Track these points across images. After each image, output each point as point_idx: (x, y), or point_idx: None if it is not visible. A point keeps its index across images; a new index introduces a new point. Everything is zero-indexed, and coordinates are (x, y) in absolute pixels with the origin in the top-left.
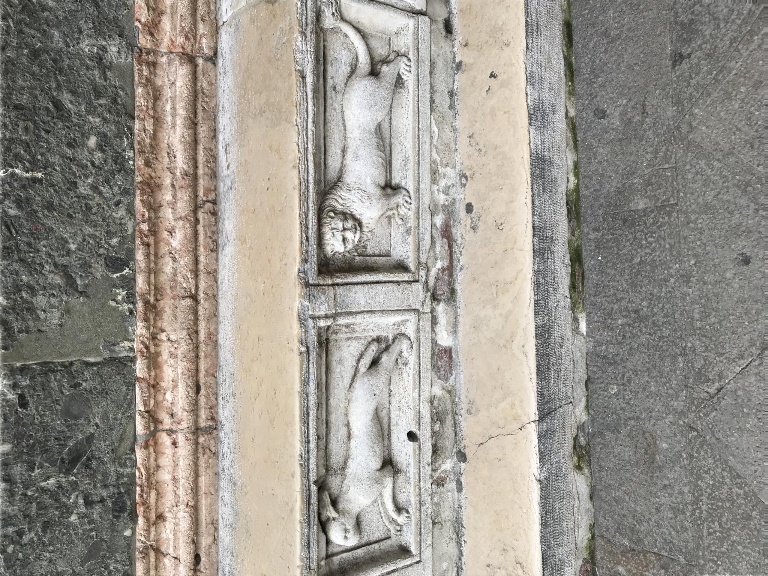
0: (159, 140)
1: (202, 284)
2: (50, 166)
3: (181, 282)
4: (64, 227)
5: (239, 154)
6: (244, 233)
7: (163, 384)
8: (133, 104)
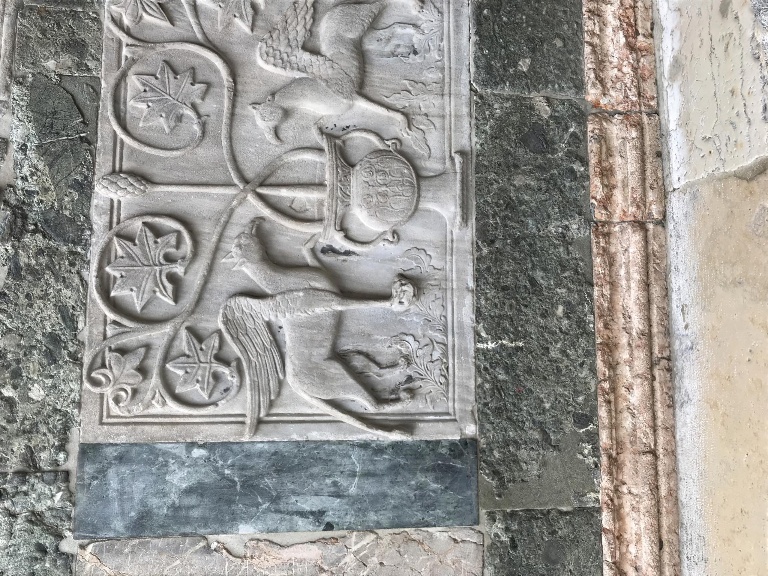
0: (614, 302)
1: (661, 439)
2: (528, 335)
3: (641, 437)
4: (540, 388)
5: (702, 317)
6: (714, 397)
7: (626, 536)
8: (591, 273)
